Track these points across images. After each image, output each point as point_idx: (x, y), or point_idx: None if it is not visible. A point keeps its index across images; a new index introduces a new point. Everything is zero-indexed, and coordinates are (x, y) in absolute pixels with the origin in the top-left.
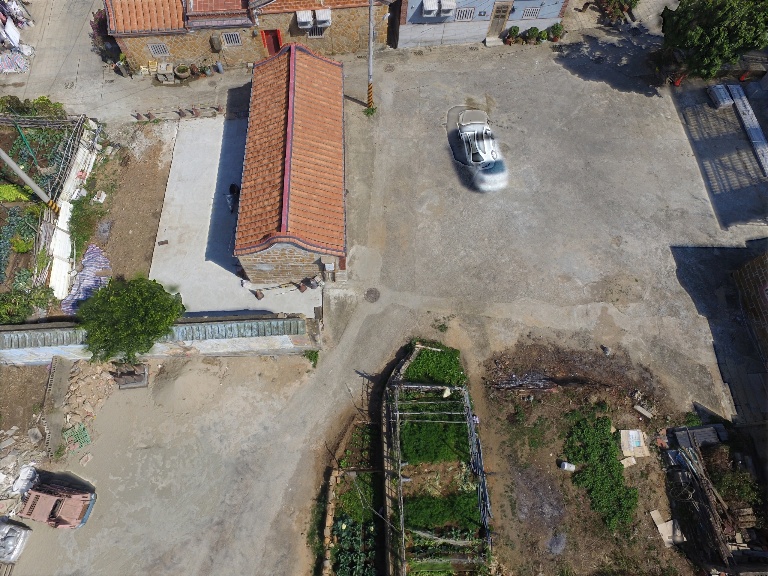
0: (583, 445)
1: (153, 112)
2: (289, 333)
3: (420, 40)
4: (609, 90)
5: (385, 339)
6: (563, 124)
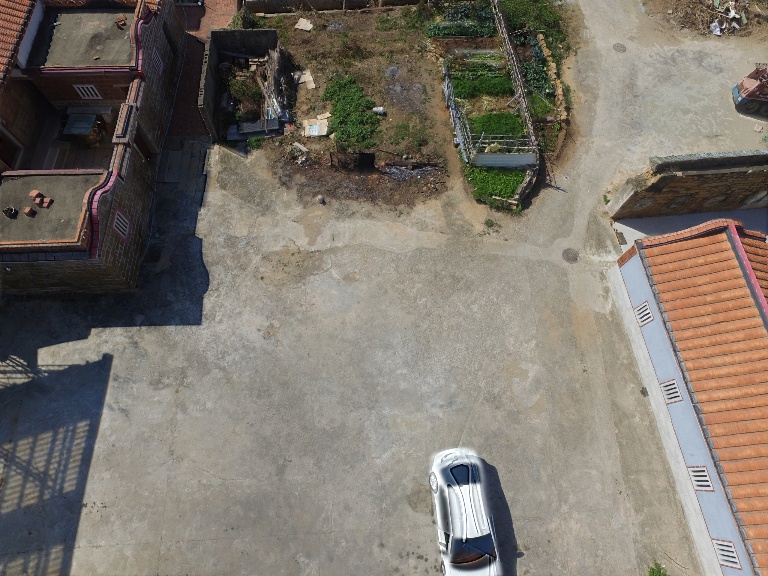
0: None
1: None
2: None
3: None
4: None
5: (546, 215)
6: (304, 573)
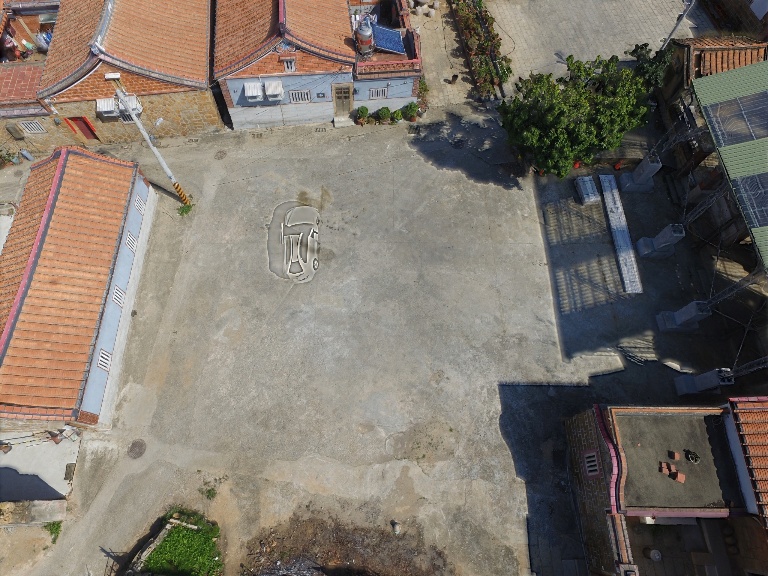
0: None
1: None
2: None
3: (258, 121)
4: (464, 181)
5: (141, 507)
6: (403, 224)
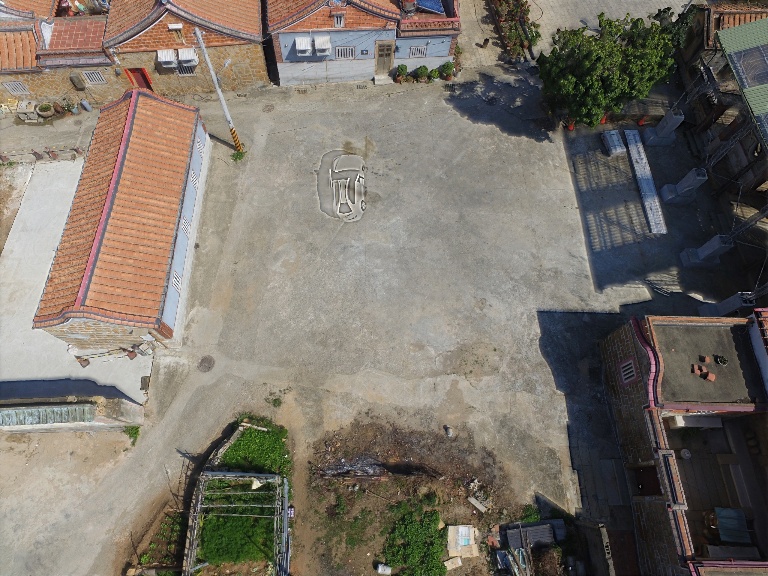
0: (405, 543)
1: (8, 154)
2: (74, 420)
3: (303, 78)
4: (498, 134)
5: (213, 414)
6: (443, 172)
